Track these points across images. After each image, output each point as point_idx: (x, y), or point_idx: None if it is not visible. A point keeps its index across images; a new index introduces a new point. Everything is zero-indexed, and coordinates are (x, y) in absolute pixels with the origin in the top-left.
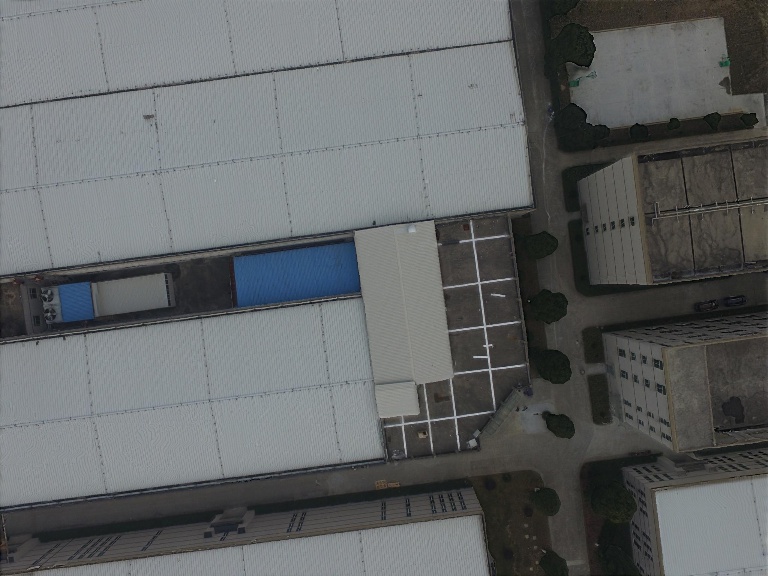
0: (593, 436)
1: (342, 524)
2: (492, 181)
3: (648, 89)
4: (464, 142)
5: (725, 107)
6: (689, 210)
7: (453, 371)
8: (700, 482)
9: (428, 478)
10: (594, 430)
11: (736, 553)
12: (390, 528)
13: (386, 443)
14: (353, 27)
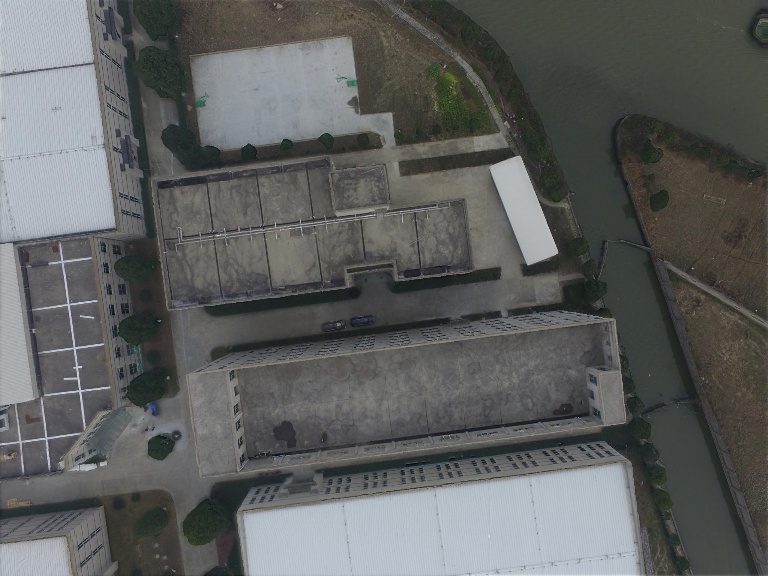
0: None
1: None
2: (76, 203)
3: (276, 109)
4: (46, 165)
5: (353, 127)
6: (212, 235)
7: (33, 393)
8: (292, 504)
9: (59, 497)
10: None
11: (324, 575)
12: None
13: None
14: None
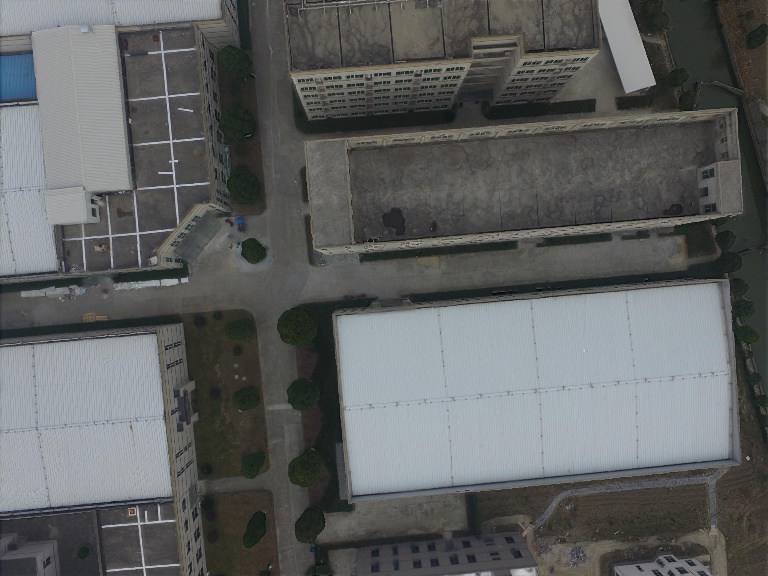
0: (309, 278)
1: (20, 340)
2: None
3: None
4: None
5: None
6: (336, 2)
7: (129, 181)
8: (386, 311)
9: (138, 313)
10: (310, 271)
11: (418, 384)
12: (65, 344)
13: (64, 256)
14: None
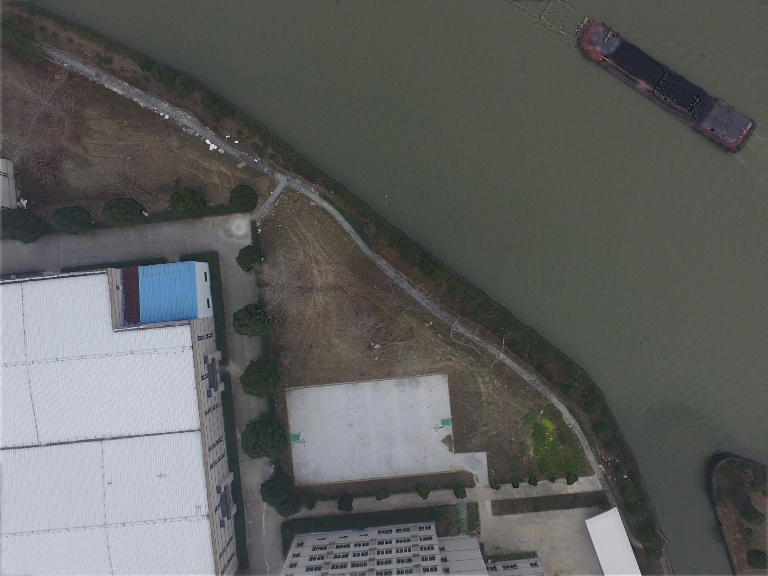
0: None
1: None
2: (178, 570)
3: (369, 444)
4: (150, 532)
5: (447, 465)
6: None
7: None
8: None
9: None
10: None
11: None
12: None
13: None
14: (47, 413)
